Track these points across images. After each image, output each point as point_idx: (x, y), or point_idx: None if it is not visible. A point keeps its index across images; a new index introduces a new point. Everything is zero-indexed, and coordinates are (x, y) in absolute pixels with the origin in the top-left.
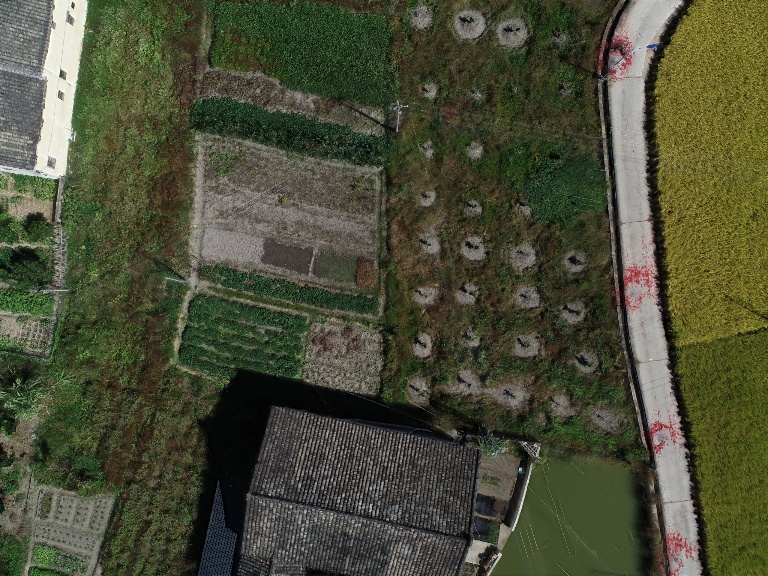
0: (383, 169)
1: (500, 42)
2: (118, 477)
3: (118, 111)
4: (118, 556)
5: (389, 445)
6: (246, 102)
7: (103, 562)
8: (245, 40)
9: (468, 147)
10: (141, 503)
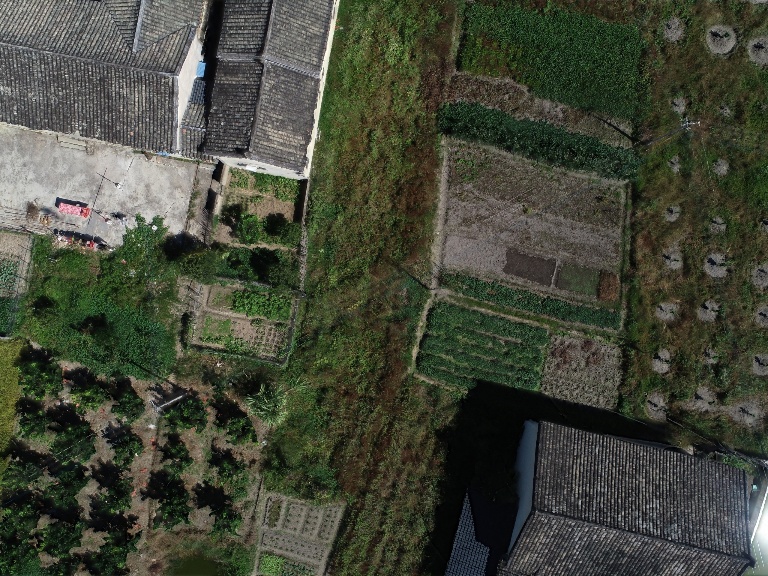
0: (628, 182)
1: (750, 58)
2: (353, 486)
3: (363, 112)
4: (349, 566)
5: (658, 463)
6: (494, 108)
7: (335, 572)
8: (496, 45)
9: (715, 163)
10: (376, 513)
